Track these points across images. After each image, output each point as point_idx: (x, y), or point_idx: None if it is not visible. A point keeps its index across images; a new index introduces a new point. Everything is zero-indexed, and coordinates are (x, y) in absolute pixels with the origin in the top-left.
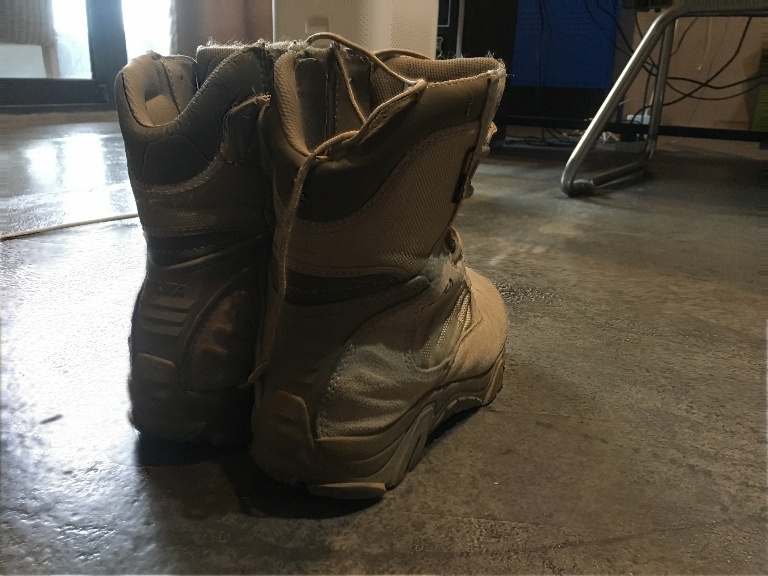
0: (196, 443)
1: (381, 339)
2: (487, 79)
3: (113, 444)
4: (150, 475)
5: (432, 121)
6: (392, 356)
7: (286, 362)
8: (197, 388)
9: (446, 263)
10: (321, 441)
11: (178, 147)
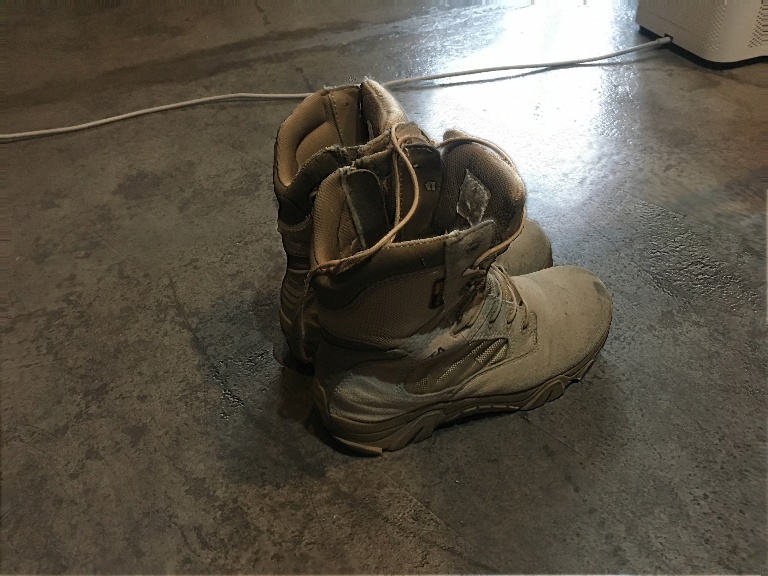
0: (307, 366)
1: (375, 374)
2: (444, 242)
3: (281, 340)
4: (282, 374)
5: (385, 272)
6: (383, 385)
7: (320, 364)
8: (305, 340)
9: (442, 334)
10: (331, 416)
11: (287, 205)
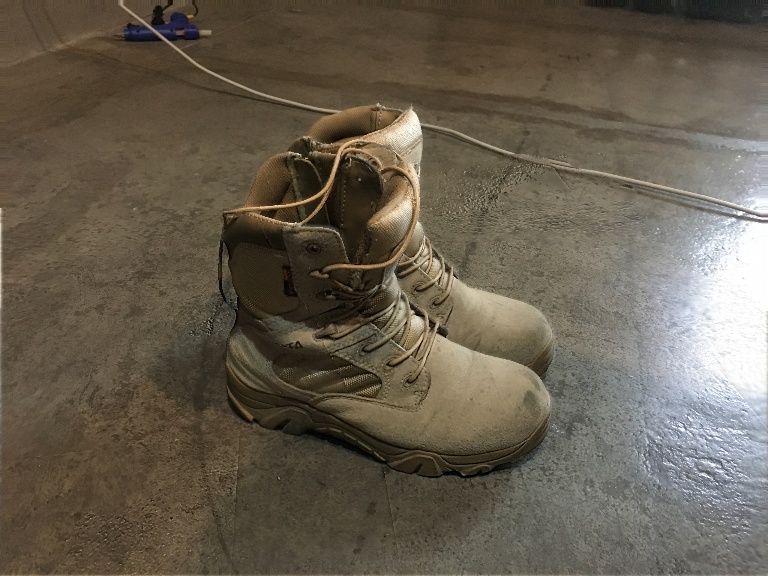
0: None
1: (254, 340)
2: (282, 227)
3: None
4: None
5: (243, 235)
6: (257, 354)
7: None
8: None
9: (305, 331)
10: None
11: None
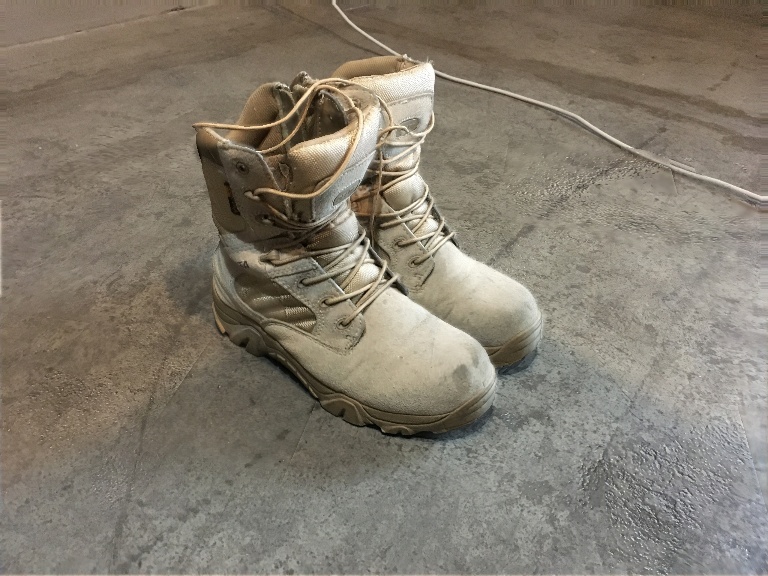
0: None
1: None
2: None
3: None
4: None
5: None
6: (225, 269)
7: None
8: None
9: (253, 253)
10: (213, 276)
11: None
